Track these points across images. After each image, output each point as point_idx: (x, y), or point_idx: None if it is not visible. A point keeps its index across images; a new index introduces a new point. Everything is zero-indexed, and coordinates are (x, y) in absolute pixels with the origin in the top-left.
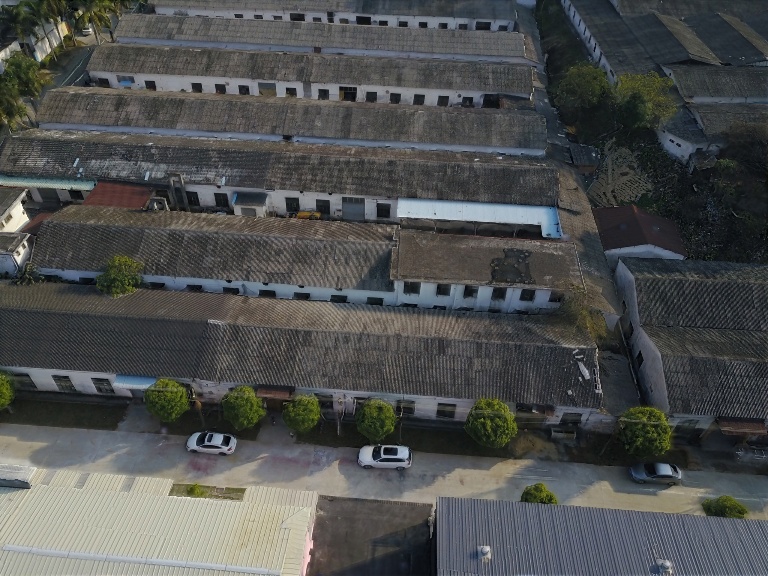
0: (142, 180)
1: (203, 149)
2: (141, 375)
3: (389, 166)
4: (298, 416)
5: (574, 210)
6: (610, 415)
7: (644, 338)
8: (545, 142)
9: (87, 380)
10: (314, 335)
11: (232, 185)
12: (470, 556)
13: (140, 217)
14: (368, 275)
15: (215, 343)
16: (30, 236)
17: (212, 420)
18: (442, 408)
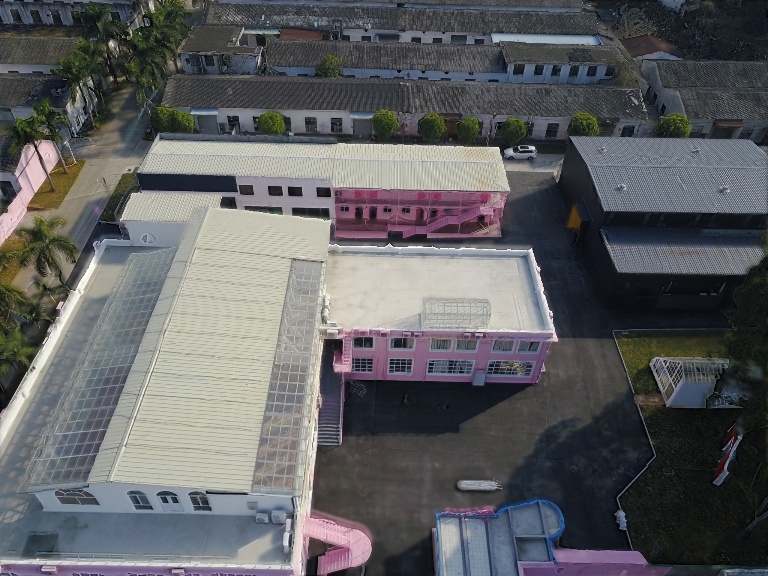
0: (313, 27)
1: (350, 7)
2: (366, 111)
3: (481, 15)
4: (470, 125)
5: (609, 37)
6: (652, 125)
7: (666, 93)
8: (581, 3)
9: (327, 120)
10: (468, 89)
11: (376, 28)
12: (596, 151)
13: (327, 41)
14: (489, 64)
15: (408, 94)
16: (263, 48)
17: (407, 144)
18: (550, 128)
